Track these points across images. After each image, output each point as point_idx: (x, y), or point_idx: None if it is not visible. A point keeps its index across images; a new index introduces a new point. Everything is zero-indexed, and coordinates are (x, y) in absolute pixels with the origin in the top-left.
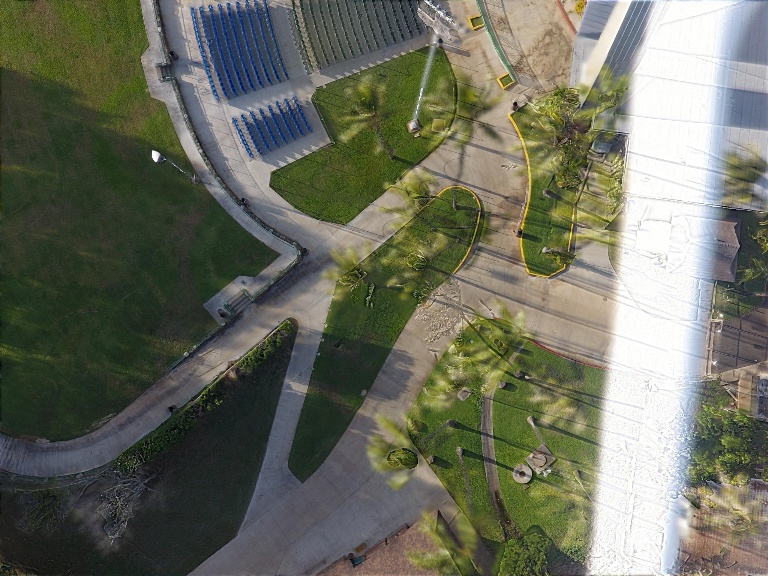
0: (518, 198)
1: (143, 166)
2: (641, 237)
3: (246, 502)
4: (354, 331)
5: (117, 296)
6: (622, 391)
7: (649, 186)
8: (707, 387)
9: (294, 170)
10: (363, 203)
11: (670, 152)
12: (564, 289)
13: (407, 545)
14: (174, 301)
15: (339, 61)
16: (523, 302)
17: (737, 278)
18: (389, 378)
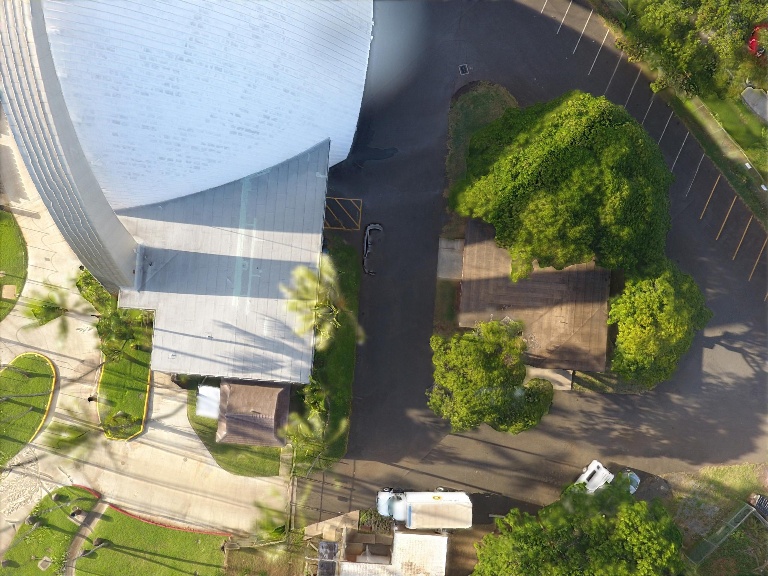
0: (94, 361)
1: None
2: (200, 403)
3: None
4: None
5: None
6: (204, 552)
7: (176, 363)
8: (290, 542)
9: None
10: None
11: (197, 327)
12: (143, 451)
13: None
14: None
15: None
16: (103, 467)
17: None
18: None
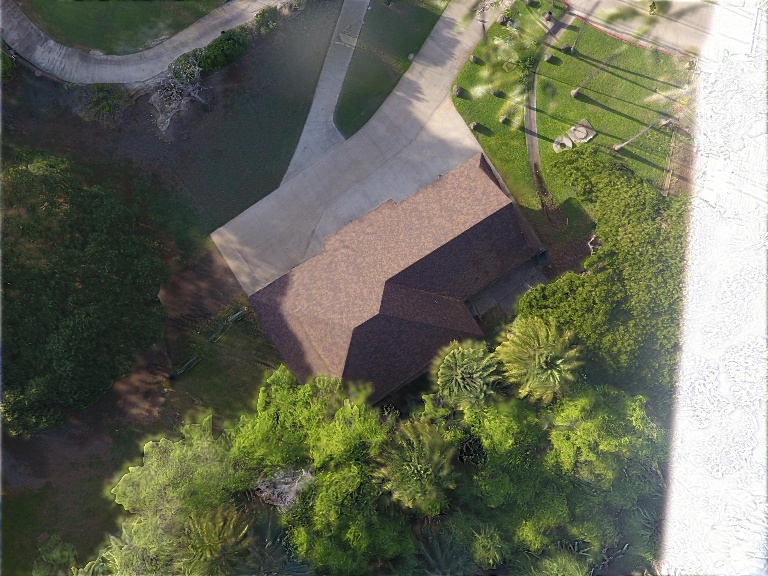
0: None
1: None
2: None
3: (290, 153)
4: None
5: None
6: (666, 71)
7: None
8: None
9: None
10: None
11: None
12: None
13: (450, 181)
14: None
15: None
16: None
17: None
18: (436, 44)
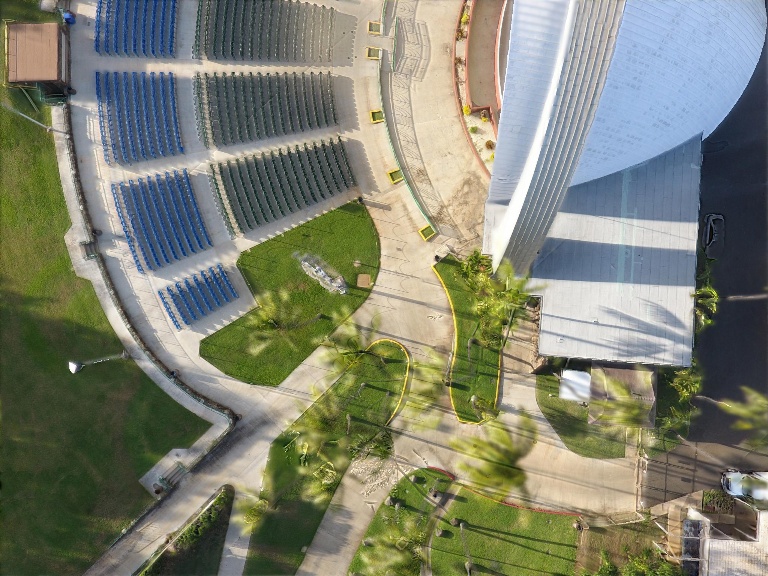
0: (445, 347)
1: (72, 346)
2: (563, 386)
3: None
4: (290, 491)
5: (52, 479)
6: (555, 531)
7: (564, 347)
8: (638, 522)
9: (223, 337)
10: (293, 363)
11: (583, 312)
12: (494, 434)
13: None
14: (109, 480)
15: (262, 225)
16: (455, 449)
17: (657, 424)
18: (328, 533)
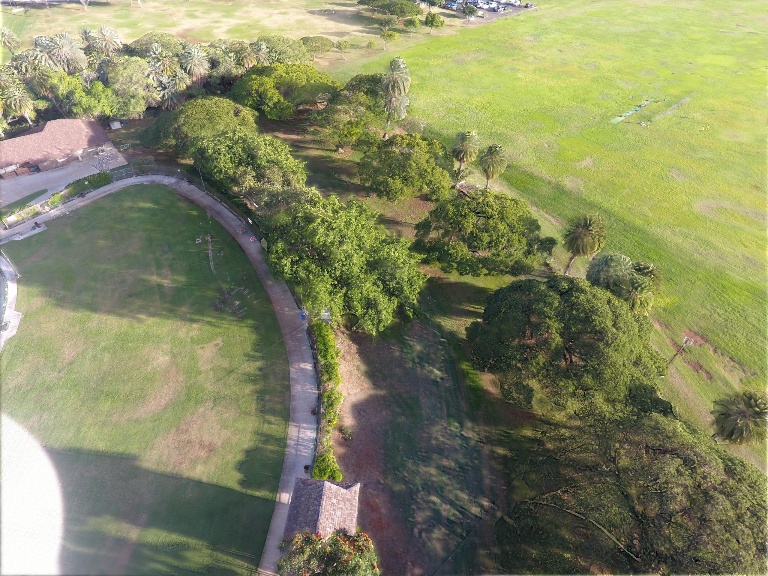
0: None
1: None
2: None
3: None
4: None
5: (91, 228)
6: None
7: None
8: None
9: None
10: None
11: None
12: None
13: None
14: None
15: None
16: None
17: None
18: None
